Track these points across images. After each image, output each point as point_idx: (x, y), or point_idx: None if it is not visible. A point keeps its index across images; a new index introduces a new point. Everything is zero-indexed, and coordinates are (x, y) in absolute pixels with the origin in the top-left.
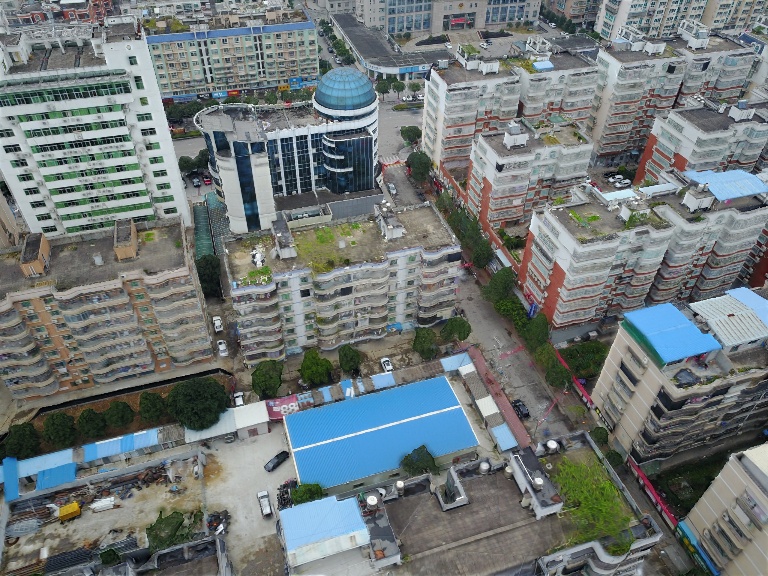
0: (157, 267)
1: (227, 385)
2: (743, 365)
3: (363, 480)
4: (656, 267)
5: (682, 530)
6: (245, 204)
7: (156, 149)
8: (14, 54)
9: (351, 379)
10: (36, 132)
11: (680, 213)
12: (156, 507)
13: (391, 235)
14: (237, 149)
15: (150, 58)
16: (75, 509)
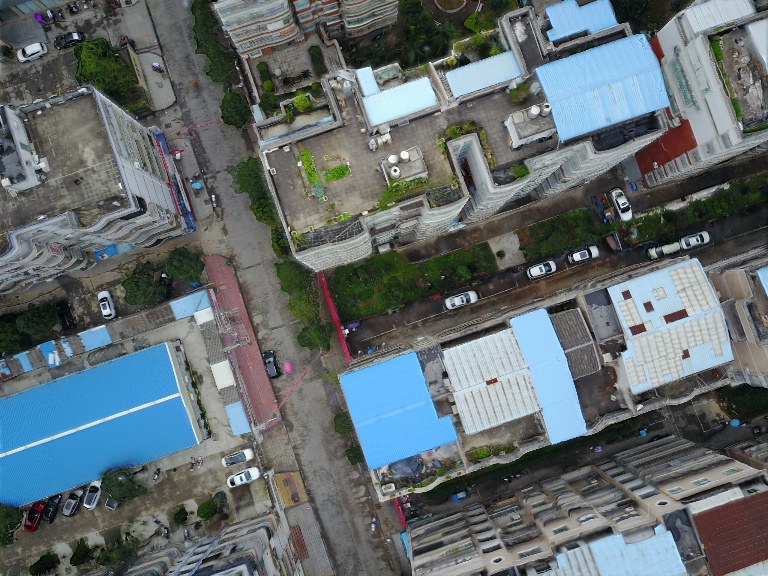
0: None
1: None
2: (490, 440)
3: (66, 491)
4: (452, 217)
5: (402, 542)
6: None
7: None
8: None
9: (52, 340)
10: None
11: (490, 156)
12: None
13: (16, 189)
14: None
15: None
16: None
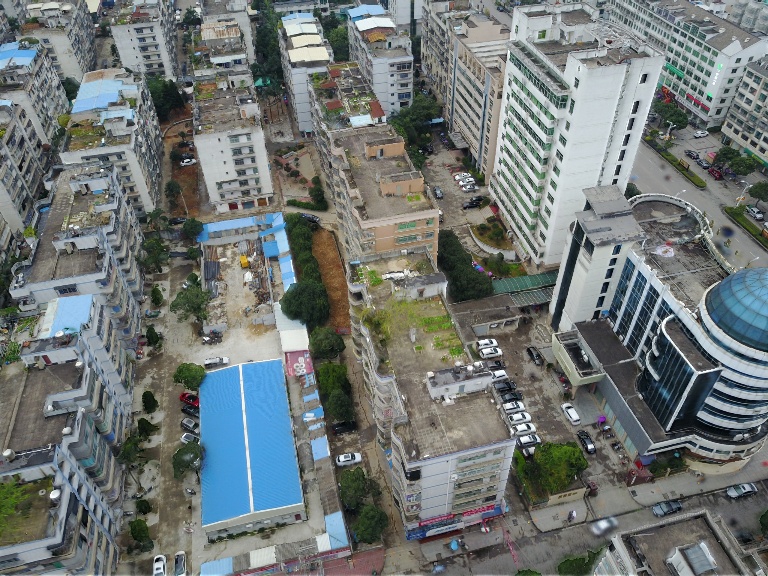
0: (371, 209)
1: (345, 329)
2: None
3: None
4: None
5: None
6: (563, 287)
7: (557, 175)
8: (568, 33)
9: (324, 416)
10: (515, 95)
11: None
12: (238, 303)
13: None
14: (577, 229)
15: (611, 96)
16: (242, 262)
